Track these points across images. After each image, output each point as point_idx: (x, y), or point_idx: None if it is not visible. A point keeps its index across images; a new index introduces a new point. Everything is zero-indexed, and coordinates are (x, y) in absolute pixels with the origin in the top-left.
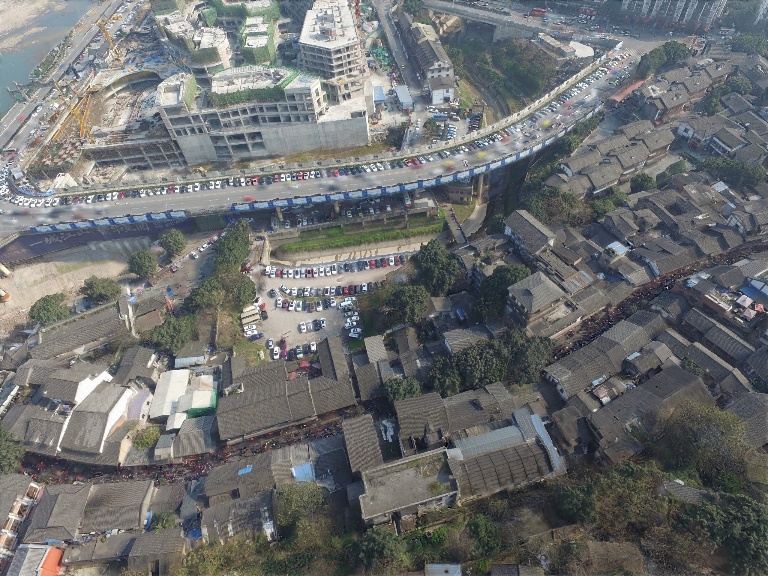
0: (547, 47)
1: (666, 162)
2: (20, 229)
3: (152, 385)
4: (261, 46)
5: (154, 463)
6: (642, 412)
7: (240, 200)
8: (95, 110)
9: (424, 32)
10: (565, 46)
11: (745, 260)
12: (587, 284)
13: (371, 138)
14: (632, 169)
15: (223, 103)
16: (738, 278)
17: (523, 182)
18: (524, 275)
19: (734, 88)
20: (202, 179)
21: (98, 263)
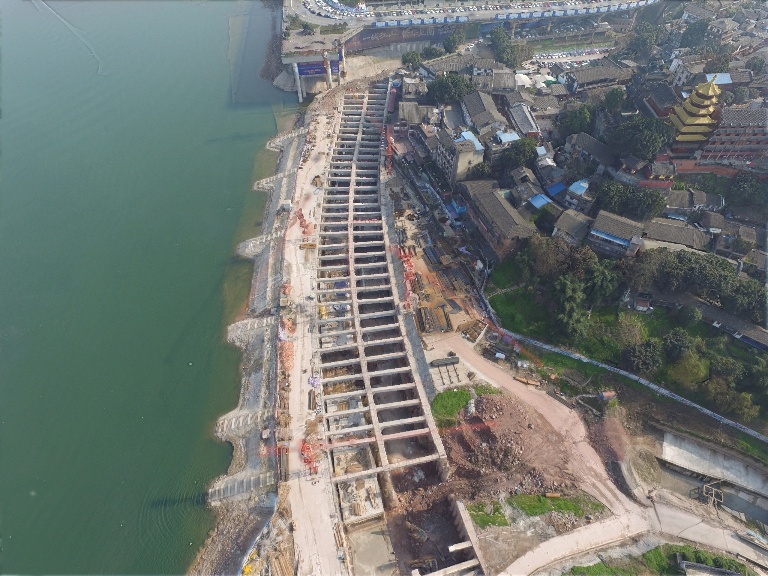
0: None
1: None
2: None
3: None
4: None
5: None
6: None
7: None
8: None
9: None
10: None
11: None
12: None
13: None
14: (738, 1)
15: None
16: None
17: (659, 21)
18: None
19: None
20: (461, 6)
21: (395, 59)
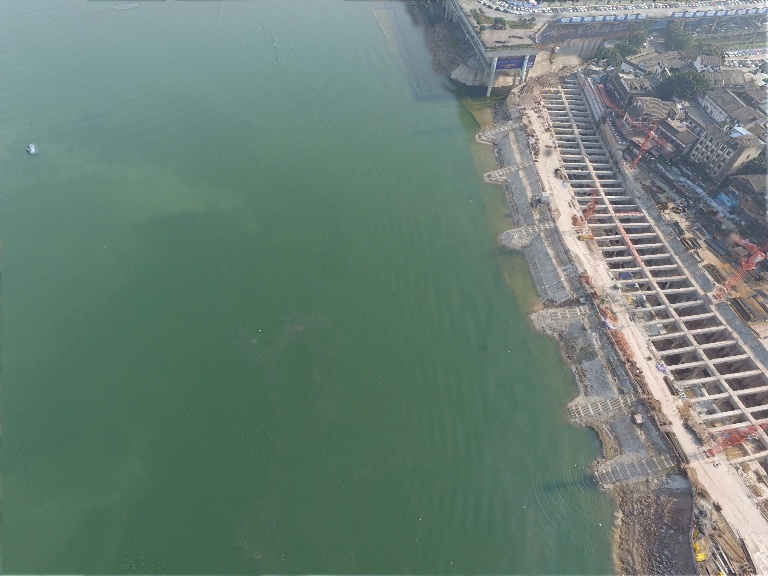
0: None
1: None
2: (545, 21)
3: None
4: None
5: None
6: None
7: (668, 14)
8: None
9: None
10: None
11: None
12: None
13: None
14: None
15: None
16: None
17: None
18: None
19: None
20: (630, 4)
21: (567, 55)
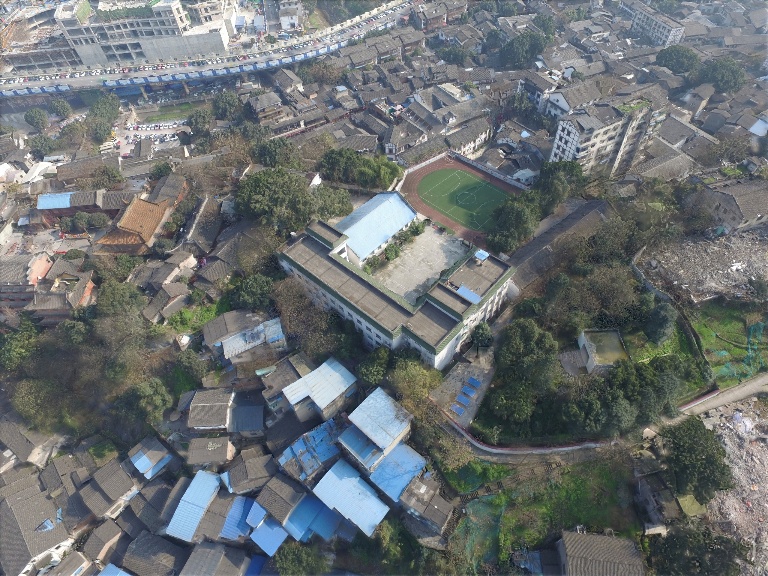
0: None
1: None
2: None
3: (27, 171)
4: None
5: (18, 197)
6: None
7: None
8: (18, 34)
9: None
10: None
11: None
12: (312, 106)
13: None
14: (388, 55)
15: (108, 19)
16: (402, 98)
17: None
18: None
19: (483, 7)
20: (88, 70)
21: None
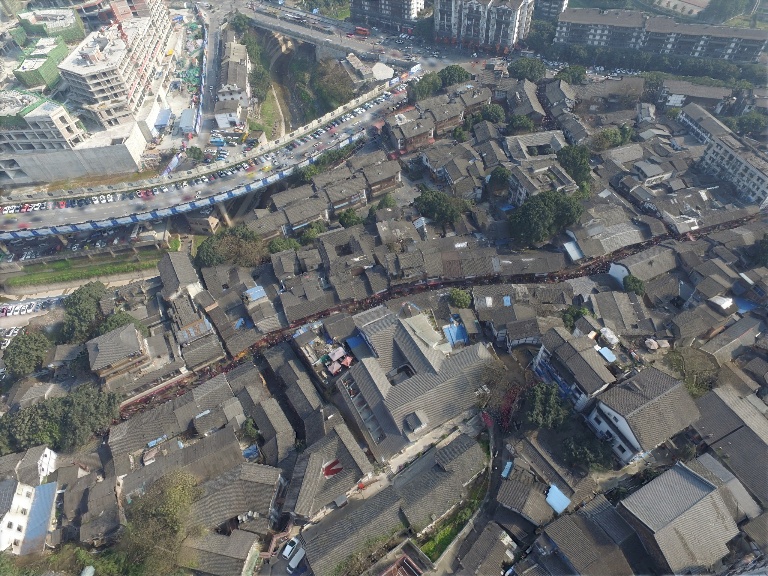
0: (351, 68)
1: (399, 193)
2: None
3: None
4: (31, 70)
5: None
6: (152, 481)
7: None
8: None
9: (232, 52)
10: (365, 68)
11: (380, 306)
12: (203, 333)
13: (141, 164)
14: (345, 203)
15: None
16: (347, 328)
17: None
18: (118, 327)
19: (486, 116)
20: None
21: None
